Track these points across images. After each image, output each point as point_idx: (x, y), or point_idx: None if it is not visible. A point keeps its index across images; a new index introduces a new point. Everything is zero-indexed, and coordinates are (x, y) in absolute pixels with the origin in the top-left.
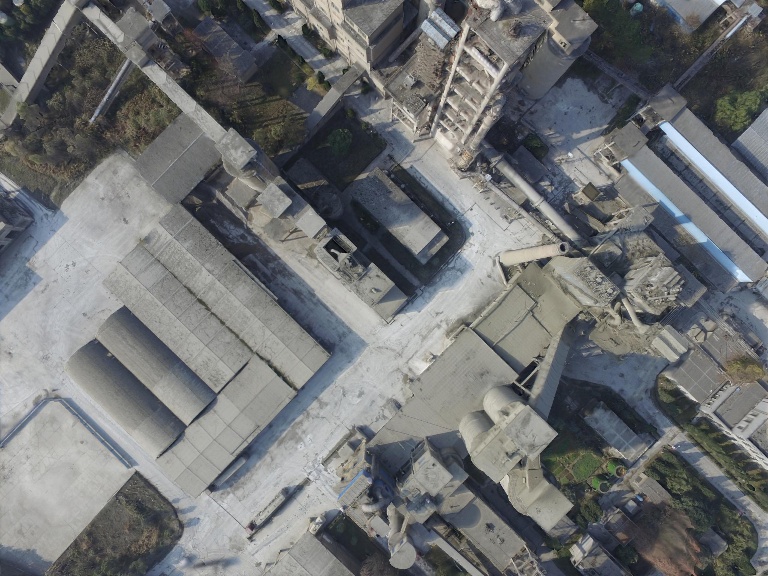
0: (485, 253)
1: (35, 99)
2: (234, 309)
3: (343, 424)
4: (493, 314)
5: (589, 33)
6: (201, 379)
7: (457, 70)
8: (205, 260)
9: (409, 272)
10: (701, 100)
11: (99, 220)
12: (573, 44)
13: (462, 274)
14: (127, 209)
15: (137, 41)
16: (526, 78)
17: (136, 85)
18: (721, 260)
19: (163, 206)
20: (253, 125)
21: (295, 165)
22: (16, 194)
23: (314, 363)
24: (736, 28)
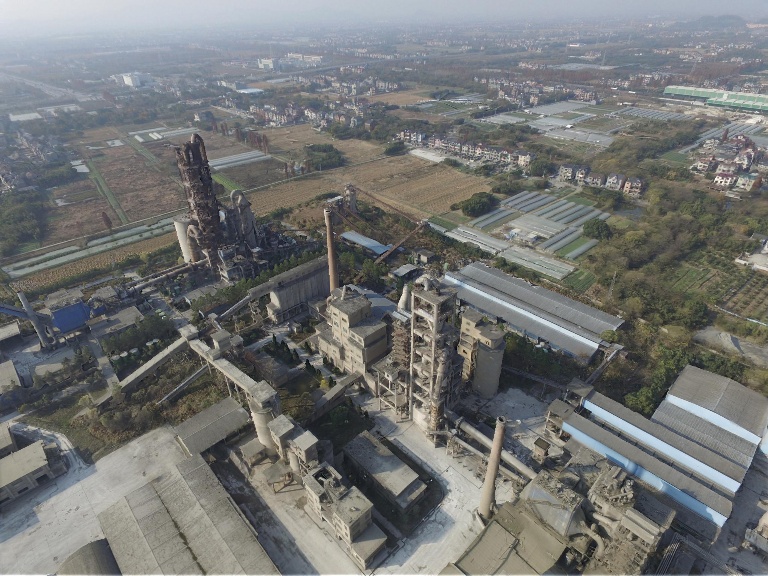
0: (464, 508)
1: (125, 392)
2: (212, 543)
3: None
4: (474, 550)
5: (501, 335)
6: None
7: (414, 332)
8: (202, 496)
9: (391, 524)
10: (610, 395)
11: (122, 473)
12: (492, 340)
13: (443, 527)
14: (151, 465)
15: (219, 344)
16: (476, 380)
17: (200, 385)
18: (688, 504)
19: None
20: None
21: None
22: (67, 452)
23: None
24: (612, 355)
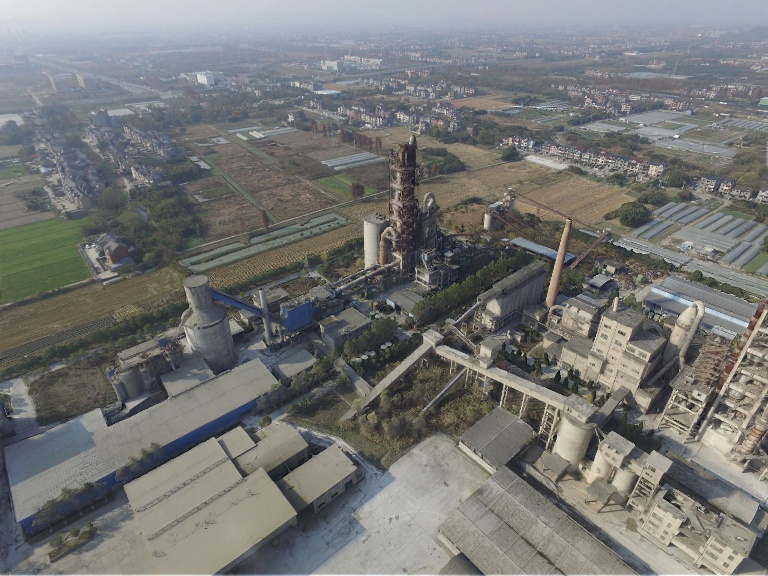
0: None
1: None
2: (580, 565)
3: None
4: None
5: None
6: None
7: (748, 351)
8: (539, 513)
9: None
10: None
11: (422, 482)
12: None
13: None
14: (447, 475)
15: (492, 352)
16: None
17: (456, 393)
18: None
19: (479, 475)
20: None
21: (593, 448)
22: (353, 456)
23: None
24: None
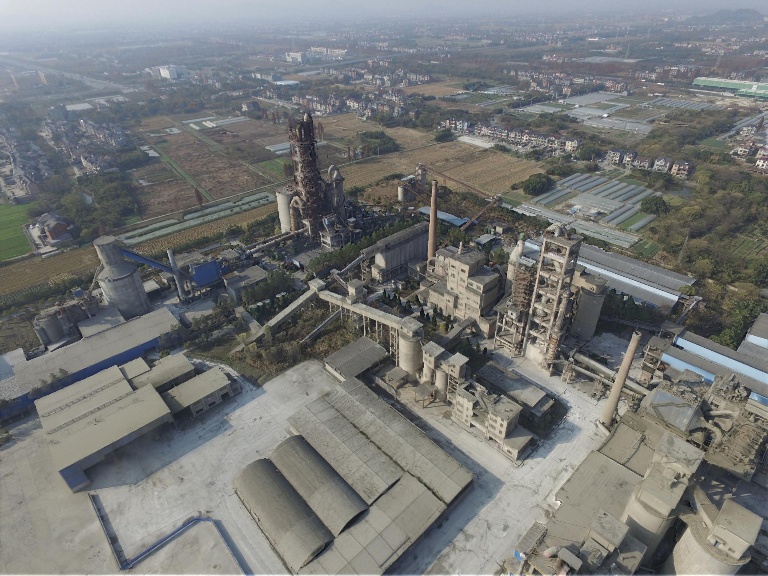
0: (586, 419)
1: None
2: (390, 438)
3: (492, 559)
4: (610, 442)
5: (604, 282)
6: (356, 492)
7: (540, 274)
8: (369, 406)
9: (528, 430)
10: None
11: (288, 393)
12: (598, 286)
13: (572, 432)
14: (310, 388)
15: (355, 290)
16: (576, 324)
17: (333, 329)
18: None
19: None
20: None
21: None
22: (235, 378)
23: (460, 480)
24: (693, 305)
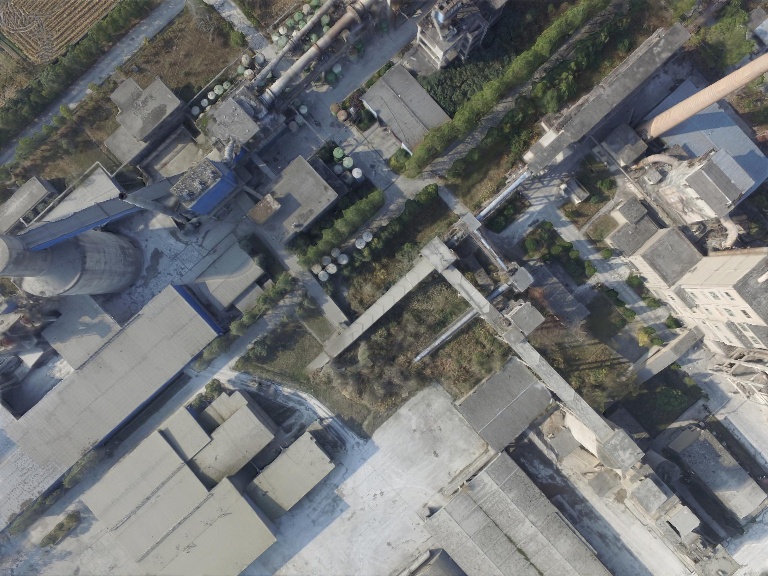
0: None
1: None
2: (554, 562)
3: None
4: None
5: None
6: None
7: None
8: (529, 511)
9: (716, 523)
10: None
11: (410, 451)
12: None
13: None
14: (438, 442)
15: None
16: None
17: None
18: None
19: (474, 442)
20: (570, 368)
21: (617, 416)
22: (329, 421)
23: None
24: None
